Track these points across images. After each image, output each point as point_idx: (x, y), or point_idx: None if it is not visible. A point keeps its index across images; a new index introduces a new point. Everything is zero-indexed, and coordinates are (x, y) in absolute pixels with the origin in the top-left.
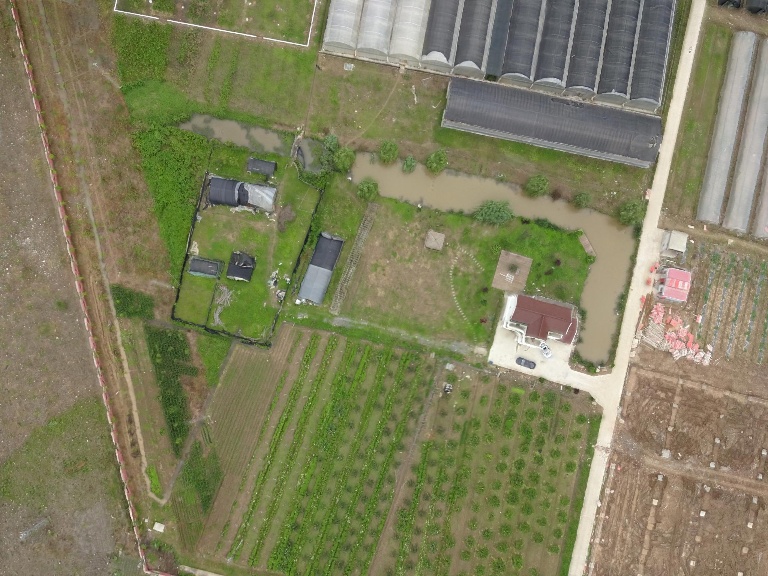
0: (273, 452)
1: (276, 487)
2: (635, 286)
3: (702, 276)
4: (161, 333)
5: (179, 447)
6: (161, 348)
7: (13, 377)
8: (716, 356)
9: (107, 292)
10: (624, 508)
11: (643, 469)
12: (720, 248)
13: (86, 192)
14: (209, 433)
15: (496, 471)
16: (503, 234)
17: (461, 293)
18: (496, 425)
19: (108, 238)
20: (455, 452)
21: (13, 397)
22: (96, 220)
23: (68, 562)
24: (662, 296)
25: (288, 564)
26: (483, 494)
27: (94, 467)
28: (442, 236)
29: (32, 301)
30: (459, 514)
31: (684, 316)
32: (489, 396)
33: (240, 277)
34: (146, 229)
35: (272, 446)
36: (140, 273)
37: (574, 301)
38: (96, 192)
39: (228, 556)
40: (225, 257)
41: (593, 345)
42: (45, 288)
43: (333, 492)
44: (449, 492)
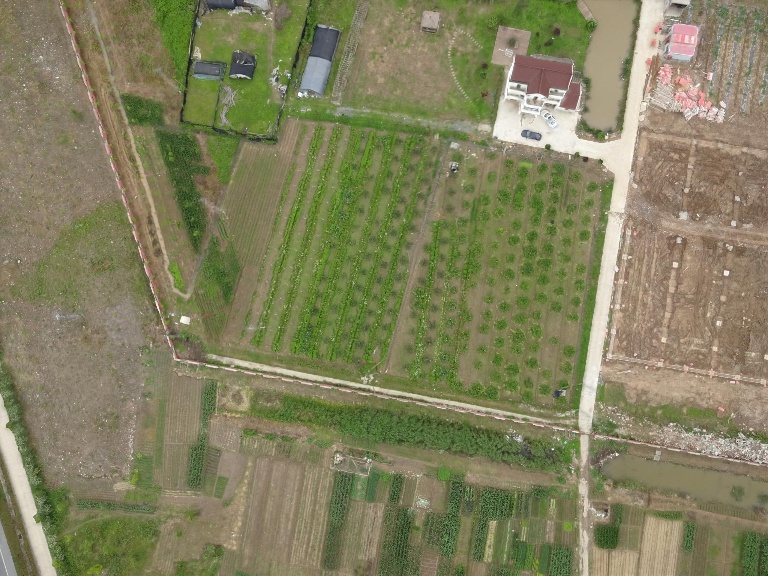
0: (287, 242)
1: (293, 275)
2: (640, 49)
3: (710, 33)
4: (172, 135)
5: (198, 242)
6: (173, 149)
7: (38, 185)
8: (730, 113)
9: (118, 103)
10: (643, 272)
11: (660, 232)
12: (727, 2)
13: (91, 10)
14: (225, 228)
15: (509, 245)
16: (499, 10)
17: (461, 72)
18: (505, 198)
19: (115, 51)
20: (466, 229)
21: (40, 204)
22: (102, 35)
23: (103, 354)
24: (668, 54)
25: (310, 347)
26: (497, 268)
27: (120, 267)
28: (437, 14)
29: (50, 114)
30: (475, 289)
31: (693, 75)
32: (496, 172)
33: (242, 74)
34: (150, 39)
35: (286, 236)
36: (148, 82)
37: (577, 69)
38: (100, 9)
39: (252, 343)
40: (227, 59)
41: (600, 113)
42: (61, 102)
43: (348, 276)
44: (463, 268)
